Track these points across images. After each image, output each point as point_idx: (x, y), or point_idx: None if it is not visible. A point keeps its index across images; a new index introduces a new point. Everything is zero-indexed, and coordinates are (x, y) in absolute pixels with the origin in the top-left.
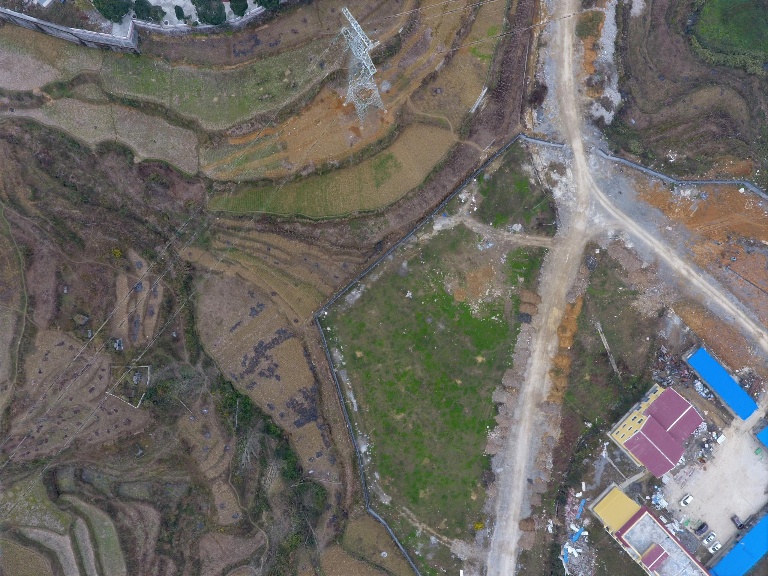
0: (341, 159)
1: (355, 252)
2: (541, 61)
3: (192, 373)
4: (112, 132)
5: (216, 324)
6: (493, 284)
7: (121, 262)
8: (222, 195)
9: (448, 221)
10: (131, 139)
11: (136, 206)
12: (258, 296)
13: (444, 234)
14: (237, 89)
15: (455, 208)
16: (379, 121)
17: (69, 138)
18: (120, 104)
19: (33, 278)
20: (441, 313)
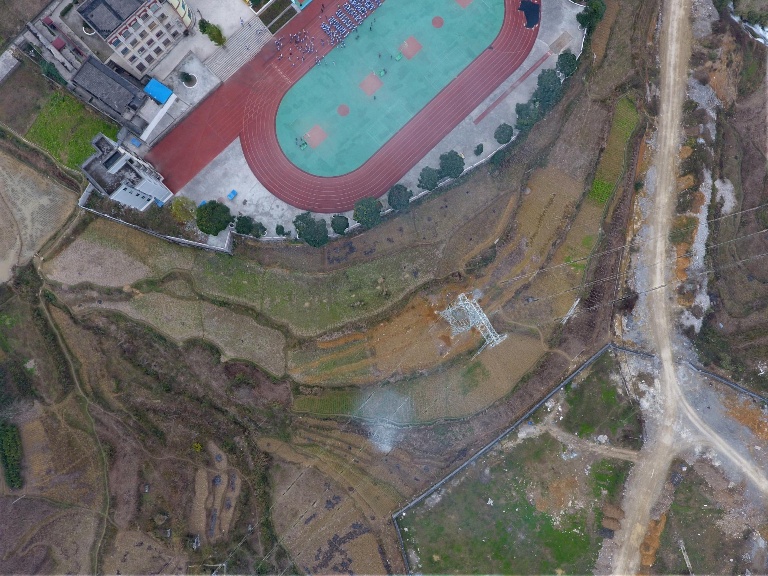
0: (430, 368)
1: (438, 457)
2: (633, 267)
3: (266, 567)
4: (200, 329)
5: (291, 515)
6: (576, 495)
7: (201, 457)
8: (307, 396)
9: (533, 429)
10: (218, 337)
11: (217, 396)
12: (334, 488)
13: (528, 442)
14: (329, 295)
15: (541, 416)
16: (470, 331)
17: (156, 334)
18: (209, 302)
19: (116, 478)
20: (522, 523)
